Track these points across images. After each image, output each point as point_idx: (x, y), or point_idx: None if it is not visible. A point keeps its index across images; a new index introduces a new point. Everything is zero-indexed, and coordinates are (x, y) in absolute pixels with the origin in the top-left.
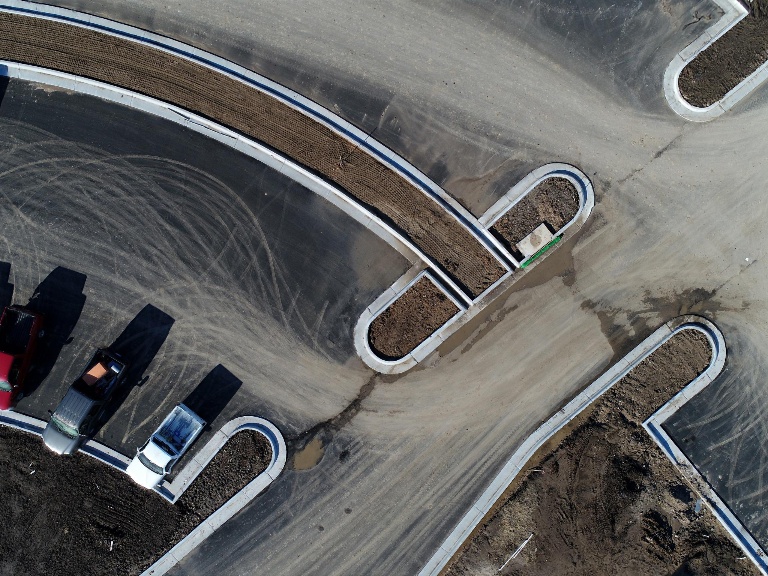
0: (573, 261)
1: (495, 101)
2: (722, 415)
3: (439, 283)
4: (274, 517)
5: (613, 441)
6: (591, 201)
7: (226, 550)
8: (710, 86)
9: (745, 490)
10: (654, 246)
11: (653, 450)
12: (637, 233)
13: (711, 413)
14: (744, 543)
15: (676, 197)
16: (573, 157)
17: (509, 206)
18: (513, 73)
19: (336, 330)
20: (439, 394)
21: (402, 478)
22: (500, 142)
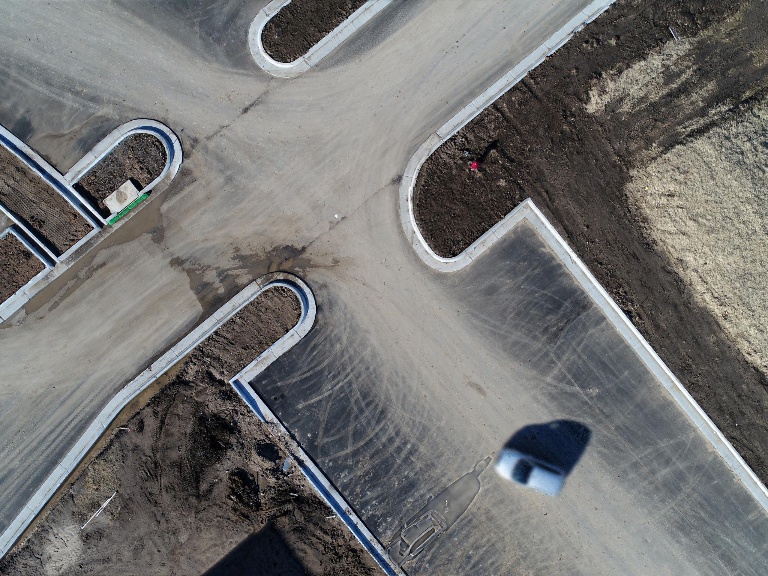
0: (162, 218)
1: (79, 57)
2: (312, 373)
3: (24, 240)
4: None
5: (200, 399)
6: (179, 157)
7: None
8: (293, 41)
9: (335, 448)
10: (243, 203)
11: (242, 408)
12: (226, 190)
13: (301, 371)
14: (332, 501)
15: (264, 153)
16: (160, 113)
17: (93, 162)
18: (97, 28)
19: None
20: (26, 352)
21: None
22: (85, 98)
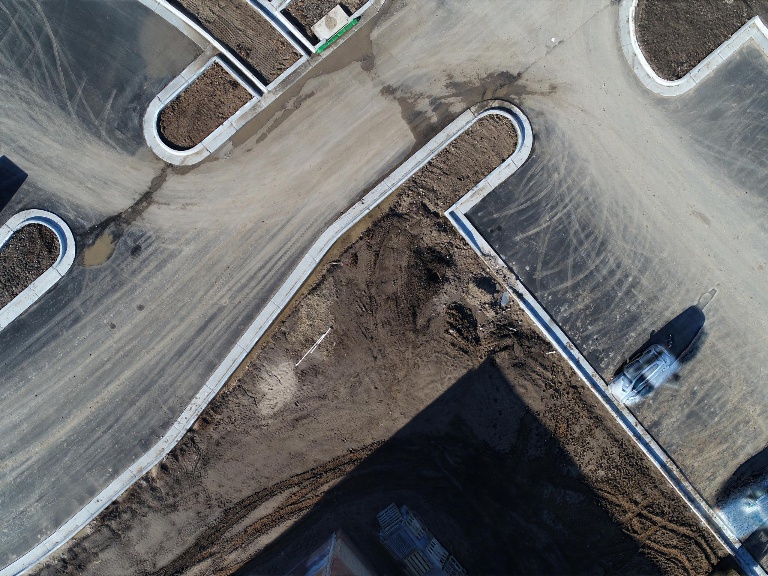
0: (371, 45)
1: None
2: (529, 204)
3: (230, 69)
4: (64, 315)
5: (415, 232)
6: None
7: (15, 349)
8: None
9: (554, 281)
10: (456, 28)
11: (457, 241)
12: (438, 14)
13: (518, 202)
14: (552, 336)
15: None
16: None
17: None
18: None
19: (125, 120)
20: (233, 185)
21: (196, 273)
22: None
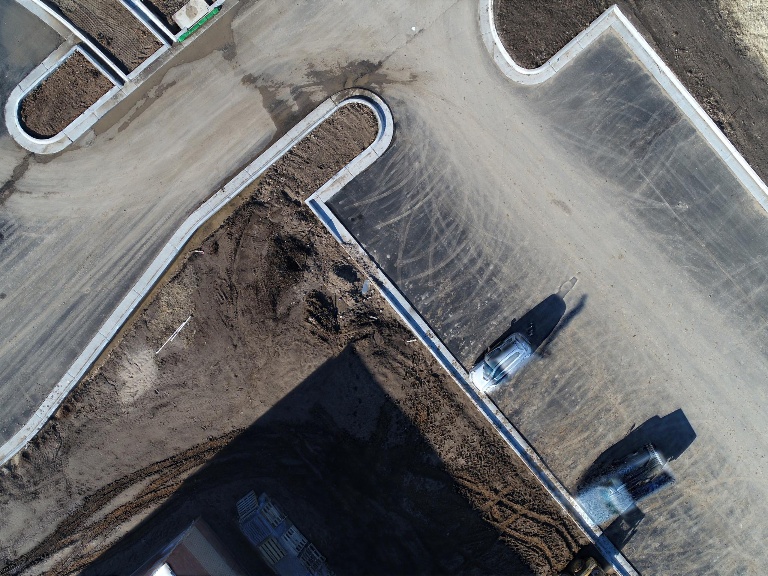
0: (233, 34)
1: None
2: (390, 192)
3: (91, 57)
4: None
5: (276, 220)
6: None
7: None
8: None
9: (415, 270)
10: (316, 16)
11: (318, 230)
12: (299, 3)
13: (379, 190)
14: (412, 324)
15: None
16: None
17: None
18: None
19: None
20: (95, 174)
21: (58, 261)
22: None
